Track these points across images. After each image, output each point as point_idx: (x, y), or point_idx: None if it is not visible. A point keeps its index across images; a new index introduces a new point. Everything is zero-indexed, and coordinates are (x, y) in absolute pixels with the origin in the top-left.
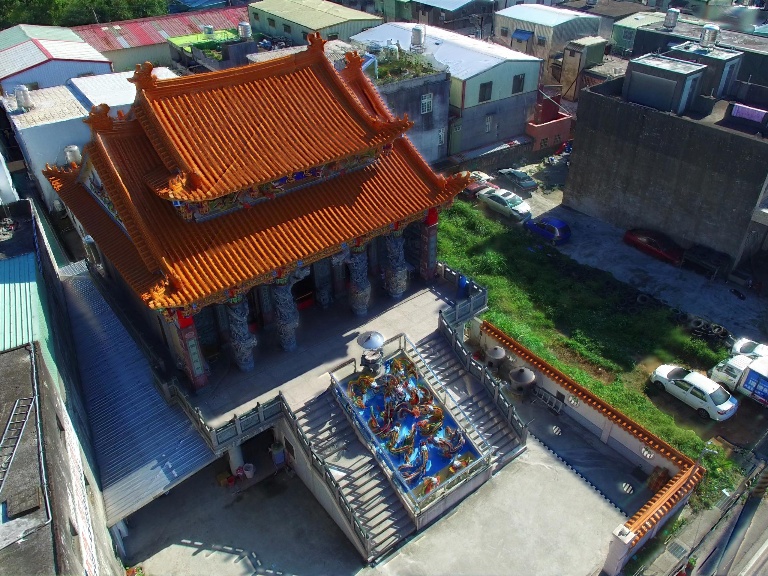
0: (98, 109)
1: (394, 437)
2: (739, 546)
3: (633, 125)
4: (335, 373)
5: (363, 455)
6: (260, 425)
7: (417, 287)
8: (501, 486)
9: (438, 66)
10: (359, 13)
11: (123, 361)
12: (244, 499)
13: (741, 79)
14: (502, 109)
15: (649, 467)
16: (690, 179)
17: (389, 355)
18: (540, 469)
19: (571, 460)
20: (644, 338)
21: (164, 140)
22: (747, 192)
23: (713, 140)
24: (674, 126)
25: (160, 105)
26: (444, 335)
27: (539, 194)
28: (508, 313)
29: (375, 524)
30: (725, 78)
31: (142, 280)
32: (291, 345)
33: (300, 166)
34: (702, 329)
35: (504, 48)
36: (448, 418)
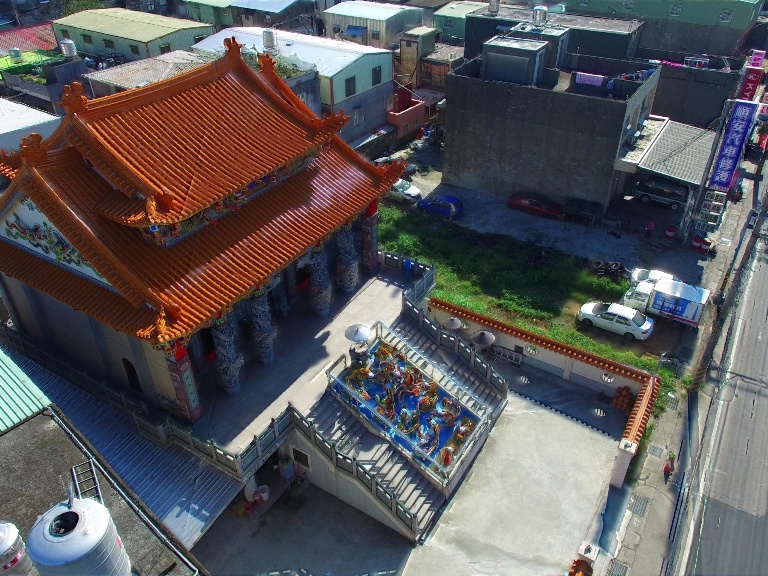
0: (29, 140)
1: (405, 419)
2: (698, 434)
3: (500, 101)
4: (325, 374)
5: (379, 444)
6: (276, 441)
7: (364, 278)
8: (501, 440)
9: (304, 66)
10: (185, 22)
11: (86, 418)
12: (268, 522)
13: (570, 52)
14: (366, 102)
15: (611, 390)
16: (557, 142)
17: (369, 345)
18: (526, 416)
19: (547, 402)
20: (559, 285)
21: (114, 165)
22: (608, 146)
23: (573, 105)
24: (537, 97)
25: (95, 128)
26: (410, 316)
27: (418, 177)
28: (440, 288)
29: (411, 505)
30: (559, 52)
31: (127, 318)
32: (271, 357)
33: (260, 173)
34: (603, 268)
35: (353, 43)
36: (439, 391)
